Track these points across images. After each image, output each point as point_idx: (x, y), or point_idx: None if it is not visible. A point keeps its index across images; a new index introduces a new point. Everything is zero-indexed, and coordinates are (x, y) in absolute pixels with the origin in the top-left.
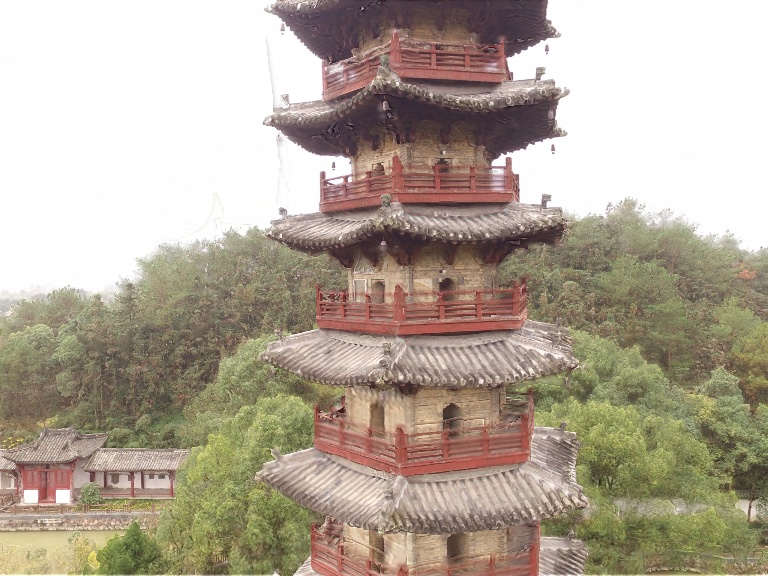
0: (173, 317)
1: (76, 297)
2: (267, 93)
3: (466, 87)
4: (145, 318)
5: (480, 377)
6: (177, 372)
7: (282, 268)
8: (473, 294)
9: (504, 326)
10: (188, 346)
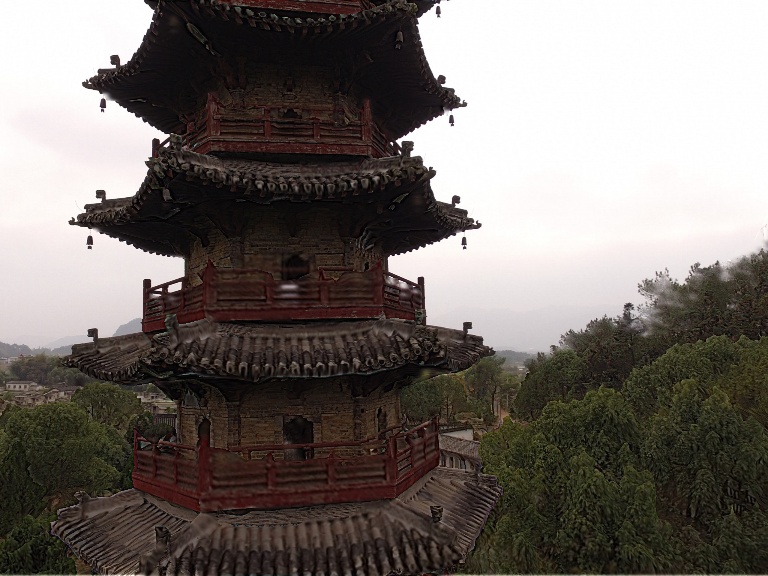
0: (672, 337)
1: (609, 325)
2: None
3: None
4: (640, 338)
5: None
6: None
7: None
8: None
9: None
10: None
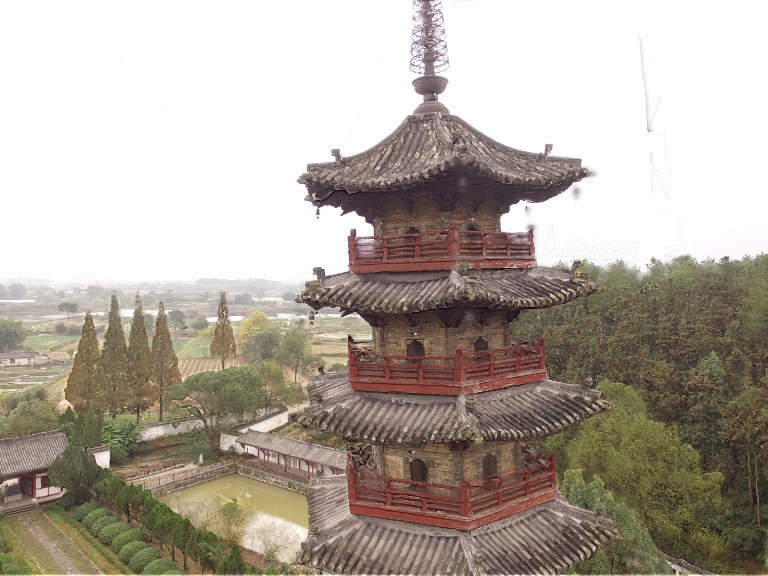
0: None
1: None
2: (639, 99)
3: (424, 274)
4: None
5: None
6: None
7: (599, 308)
8: (445, 478)
9: (450, 525)
10: None
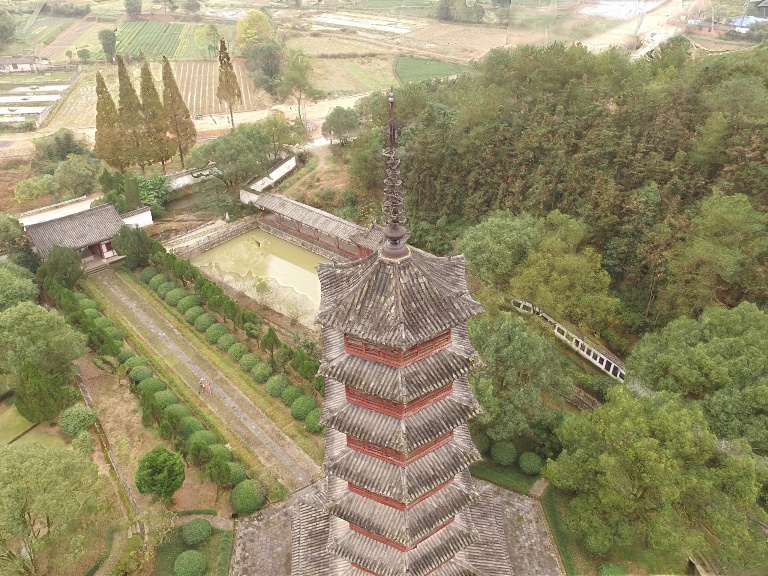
0: (473, 145)
1: (420, 97)
2: None
3: None
4: (451, 145)
5: (367, 485)
6: (469, 192)
7: (577, 112)
8: None
9: None
10: (480, 173)
